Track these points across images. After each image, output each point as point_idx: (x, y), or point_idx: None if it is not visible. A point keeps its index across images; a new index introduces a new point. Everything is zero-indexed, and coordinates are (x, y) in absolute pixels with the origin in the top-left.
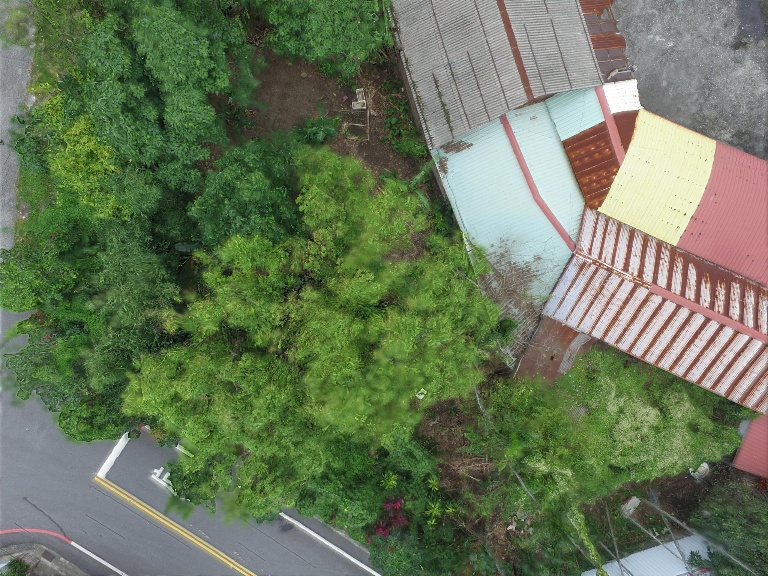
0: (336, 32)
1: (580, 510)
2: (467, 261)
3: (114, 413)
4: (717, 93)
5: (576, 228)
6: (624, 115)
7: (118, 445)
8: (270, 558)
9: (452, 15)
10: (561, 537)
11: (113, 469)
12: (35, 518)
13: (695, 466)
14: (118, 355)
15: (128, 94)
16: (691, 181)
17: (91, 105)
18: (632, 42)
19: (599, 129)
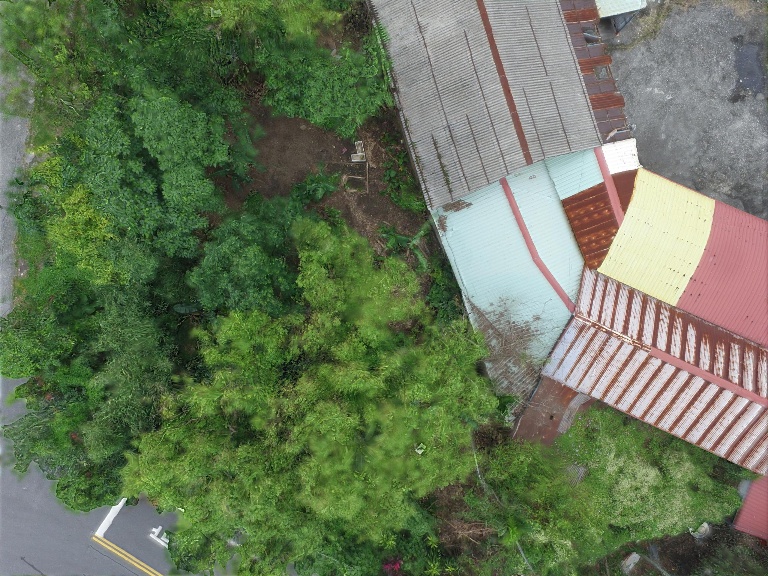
0: (335, 98)
1: (580, 566)
2: (466, 318)
3: (112, 483)
4: (716, 146)
5: (575, 289)
6: (623, 175)
7: None
8: None
9: (451, 78)
10: None
11: (111, 528)
12: None
13: (695, 526)
14: (116, 422)
15: (127, 170)
16: (690, 242)
17: (90, 174)
18: (631, 95)
19: (598, 190)
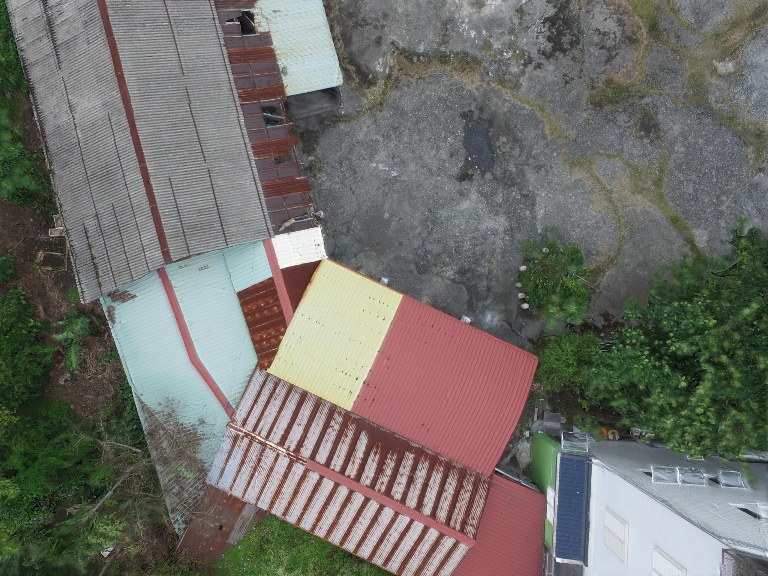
0: None
1: None
2: None
3: None
4: (440, 227)
5: (240, 392)
6: (296, 270)
7: None
8: None
9: (98, 163)
10: None
11: None
12: None
13: None
14: None
15: None
16: (363, 344)
17: None
18: (353, 170)
19: (267, 285)
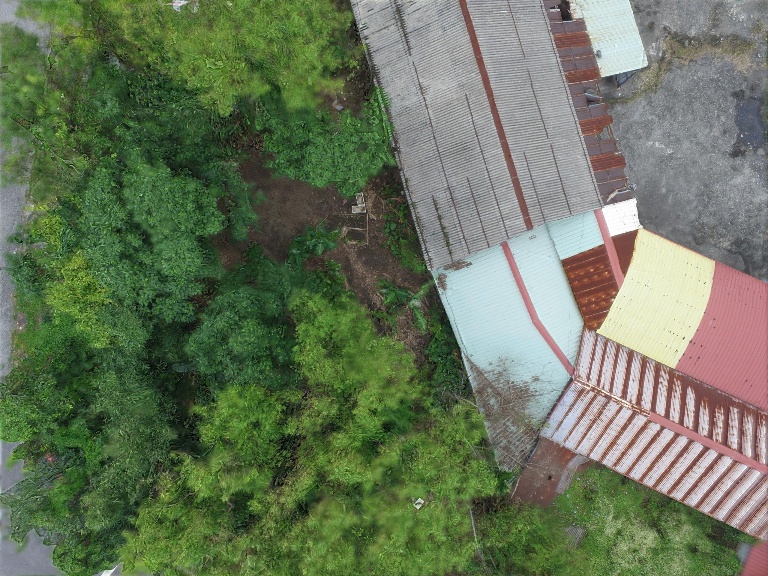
0: (336, 163)
1: None
2: None
3: (109, 550)
4: (716, 201)
5: (575, 351)
6: (623, 237)
7: None
8: None
9: (452, 140)
10: None
11: None
12: None
13: None
14: (114, 487)
15: (126, 243)
16: (690, 305)
17: (89, 240)
18: (632, 148)
19: (598, 252)
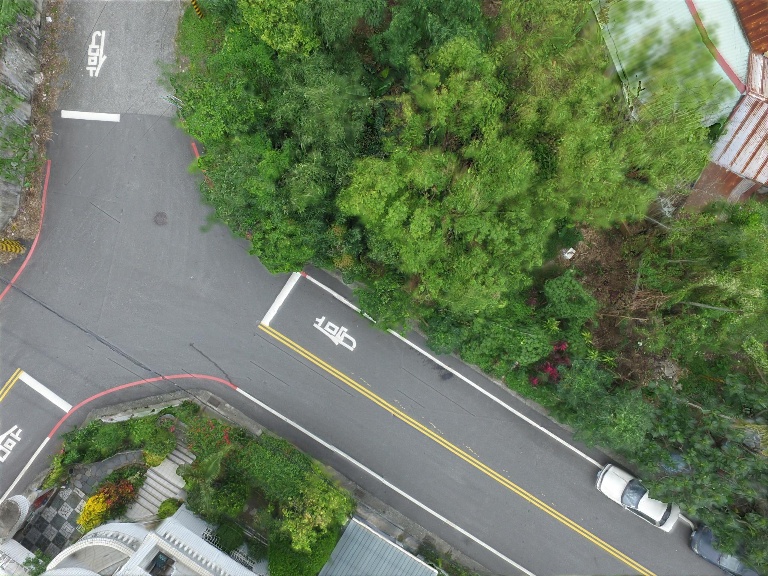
0: None
1: None
2: None
3: (307, 235)
4: None
5: (743, 72)
6: None
7: (280, 294)
8: (430, 406)
9: None
10: (712, 391)
11: (276, 318)
12: (201, 364)
13: None
14: (305, 183)
15: None
16: None
17: None
18: None
19: None
